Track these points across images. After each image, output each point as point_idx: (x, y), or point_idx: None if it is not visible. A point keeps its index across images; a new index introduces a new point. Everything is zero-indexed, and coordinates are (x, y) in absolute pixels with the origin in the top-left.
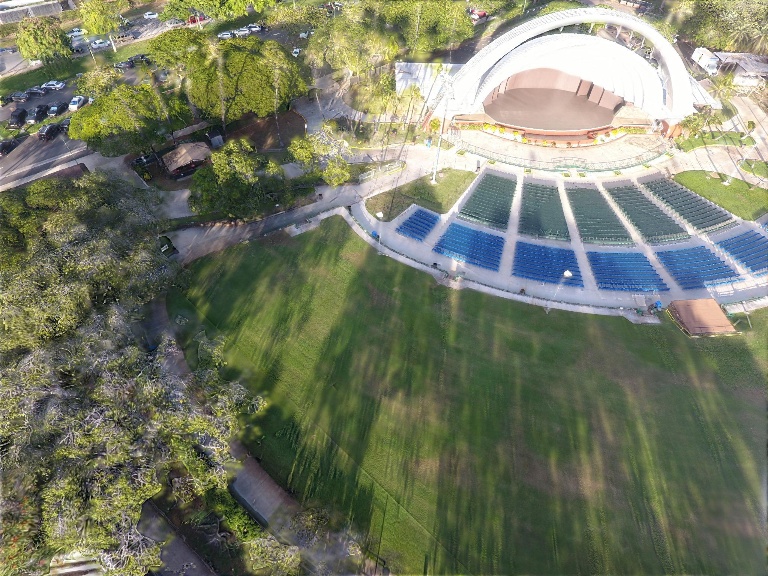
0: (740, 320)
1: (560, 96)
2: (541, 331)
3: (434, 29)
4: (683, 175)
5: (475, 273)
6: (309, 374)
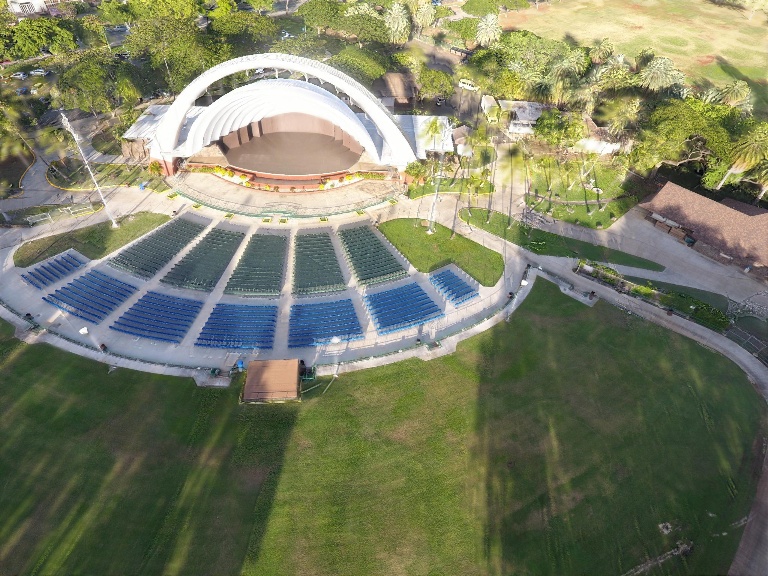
0: (320, 384)
1: (317, 140)
2: (82, 393)
3: (194, 73)
4: (391, 223)
5: (71, 325)
6: None
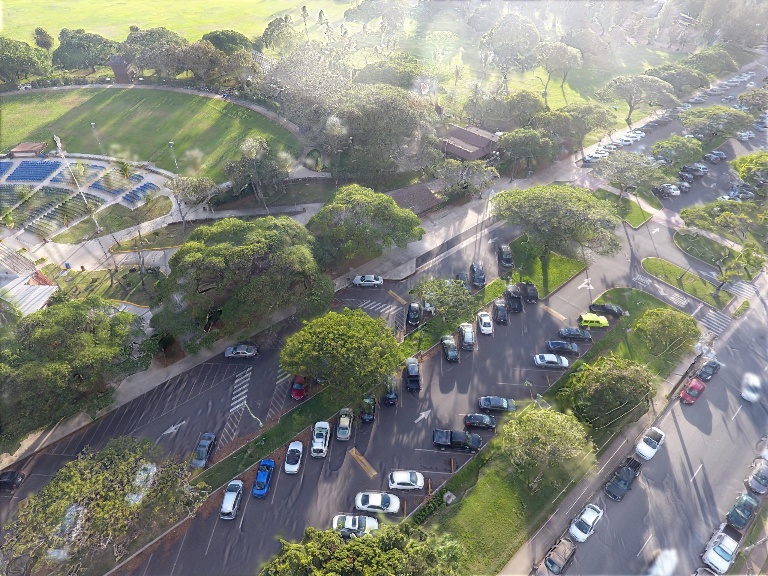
0: (8, 151)
1: None
2: (118, 147)
3: None
4: None
5: None
6: None
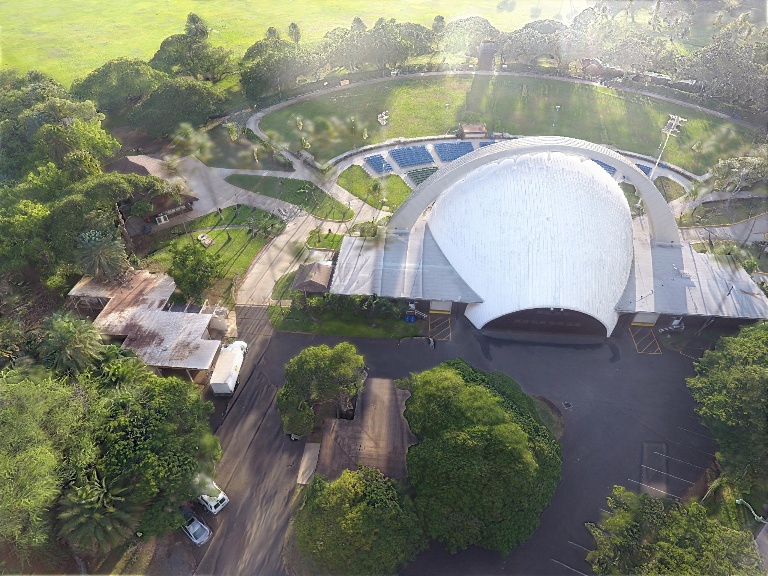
0: (452, 132)
1: None
2: (555, 130)
3: None
4: None
5: None
6: (660, 116)
